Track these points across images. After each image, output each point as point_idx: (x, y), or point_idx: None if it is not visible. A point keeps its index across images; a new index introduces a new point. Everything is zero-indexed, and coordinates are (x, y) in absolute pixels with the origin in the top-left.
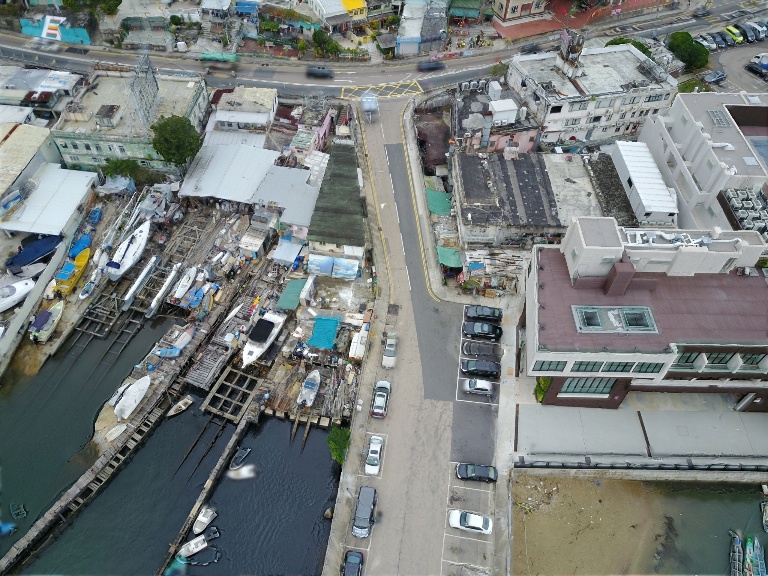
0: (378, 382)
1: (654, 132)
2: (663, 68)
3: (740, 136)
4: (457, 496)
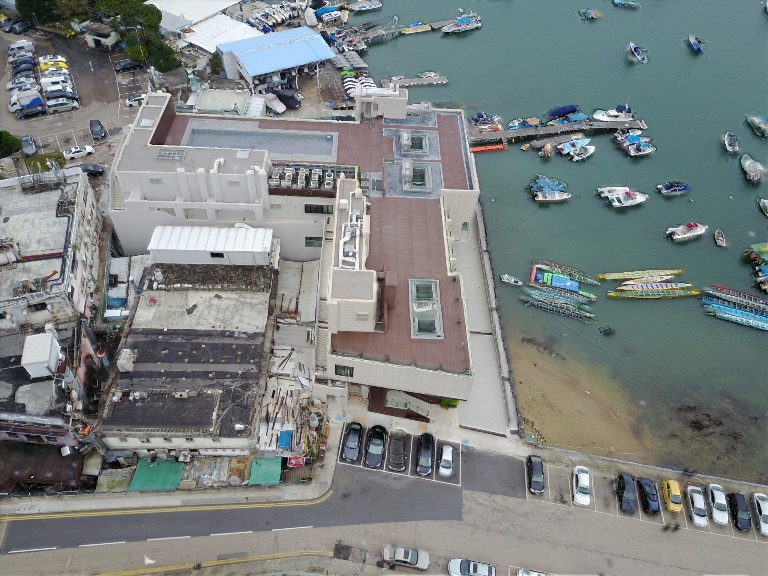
0: (452, 574)
1: (138, 214)
2: (8, 176)
3: (204, 149)
4: (559, 496)
